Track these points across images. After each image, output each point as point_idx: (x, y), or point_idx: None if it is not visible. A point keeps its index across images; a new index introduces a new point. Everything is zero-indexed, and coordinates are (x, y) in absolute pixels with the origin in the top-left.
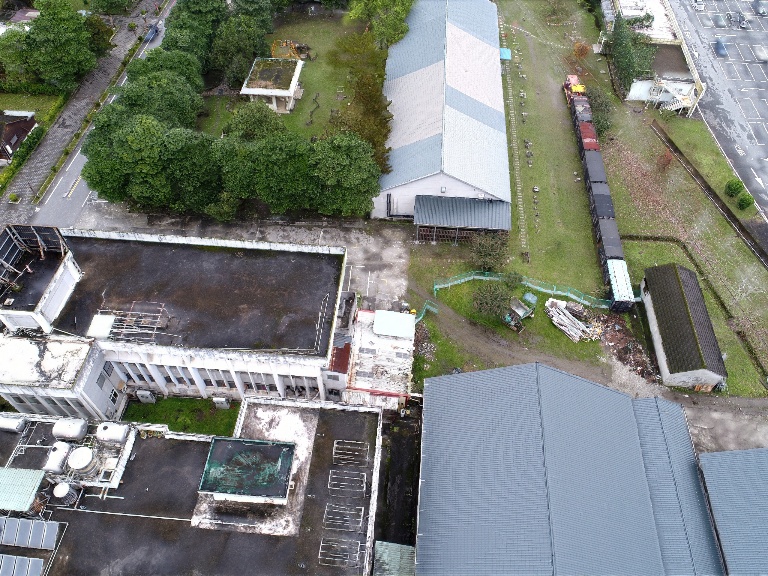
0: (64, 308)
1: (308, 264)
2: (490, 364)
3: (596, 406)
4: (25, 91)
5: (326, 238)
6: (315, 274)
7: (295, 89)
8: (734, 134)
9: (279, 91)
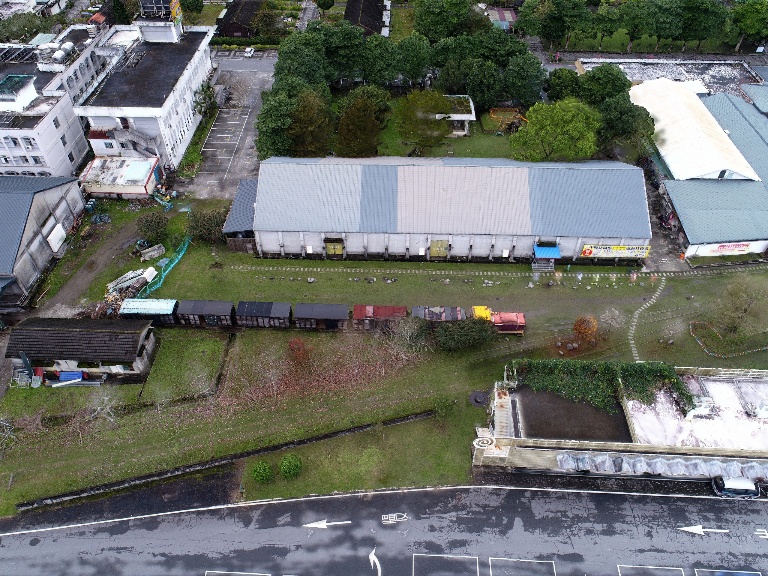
0: (155, 42)
1: (160, 102)
2: (108, 237)
3: (1, 238)
4: None
5: (259, 161)
6: (150, 105)
7: (455, 132)
8: (438, 522)
9: None
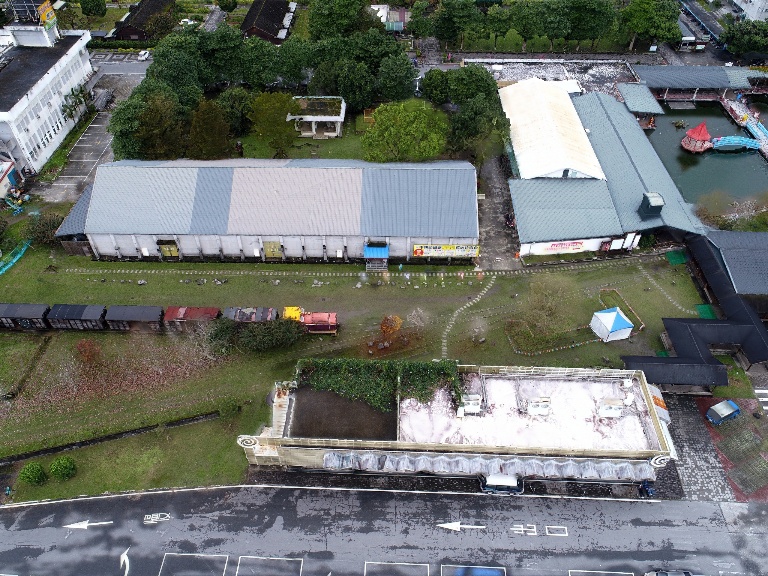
0: (29, 46)
1: None
2: None
3: None
4: None
5: None
6: (2, 110)
7: (326, 134)
8: (199, 521)
9: None
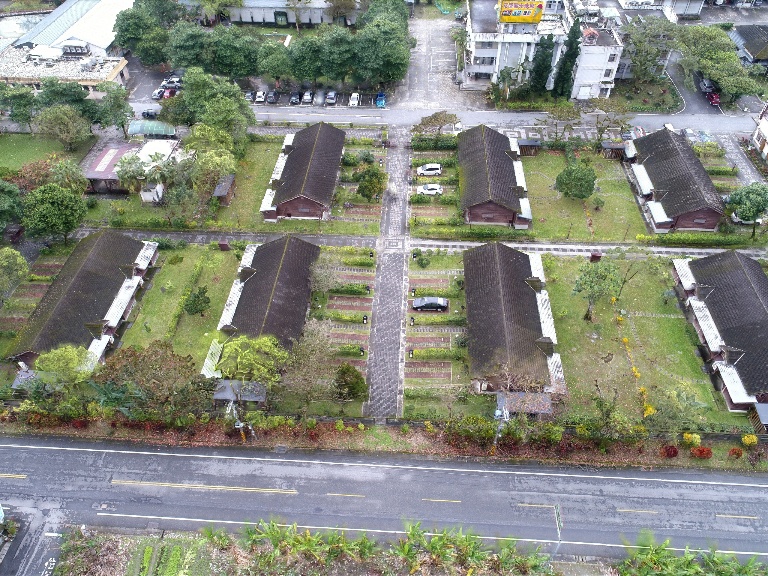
0: None
1: None
2: None
3: None
4: (243, 154)
5: None
6: None
7: None
8: None
9: (288, 38)
